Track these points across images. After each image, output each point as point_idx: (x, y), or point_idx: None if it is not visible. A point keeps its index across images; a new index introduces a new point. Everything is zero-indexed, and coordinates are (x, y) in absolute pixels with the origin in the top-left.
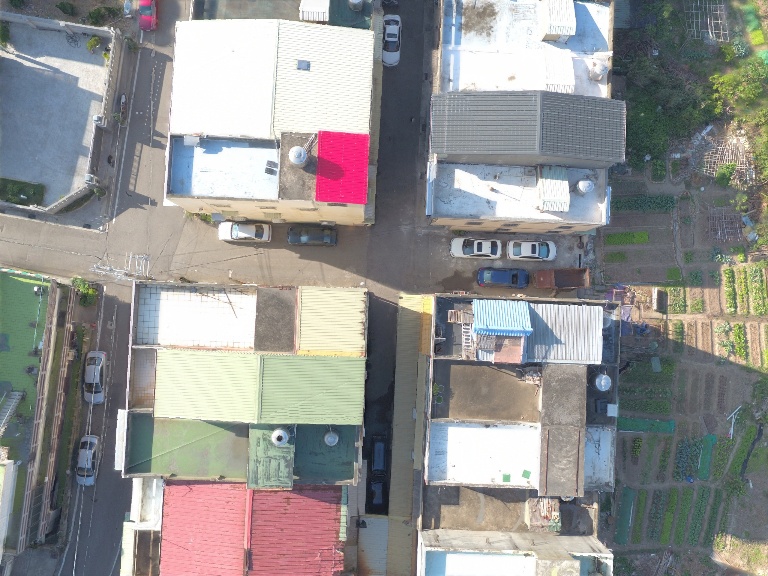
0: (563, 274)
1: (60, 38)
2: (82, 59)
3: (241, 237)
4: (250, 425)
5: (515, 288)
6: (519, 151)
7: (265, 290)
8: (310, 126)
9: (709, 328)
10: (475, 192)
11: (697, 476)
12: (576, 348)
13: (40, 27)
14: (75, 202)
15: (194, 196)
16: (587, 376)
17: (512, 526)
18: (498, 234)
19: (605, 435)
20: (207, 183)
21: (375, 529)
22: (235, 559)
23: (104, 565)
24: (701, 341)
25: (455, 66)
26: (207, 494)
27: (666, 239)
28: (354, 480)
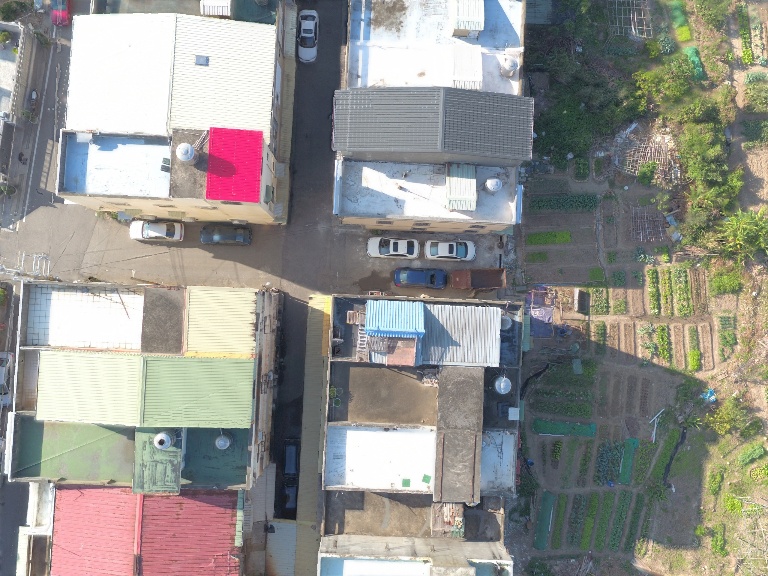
0: (481, 274)
1: None
2: None
3: (152, 236)
4: (136, 428)
5: (433, 288)
6: (421, 149)
7: (152, 290)
8: (208, 123)
9: (632, 330)
10: (383, 190)
11: (618, 480)
12: (473, 350)
13: None
14: None
15: (86, 194)
16: (489, 379)
17: (418, 531)
18: (416, 233)
19: (508, 439)
20: (101, 181)
21: (283, 534)
22: (125, 565)
23: (11, 570)
24: (624, 343)
25: (364, 62)
26: (98, 498)
27: (589, 239)
28: (246, 485)
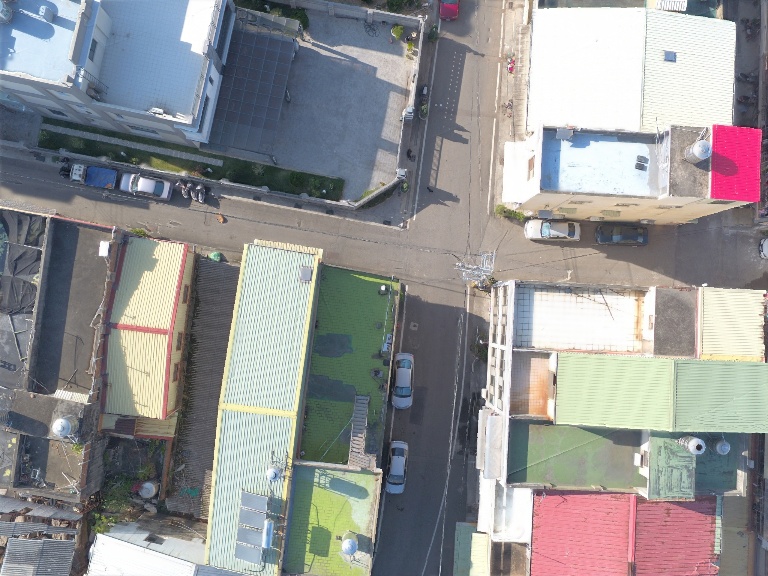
0: None
1: (357, 26)
2: (380, 49)
3: (554, 235)
4: (650, 433)
5: None
6: None
7: (664, 291)
8: (676, 120)
9: None
10: None
11: None
12: None
13: (337, 15)
14: (379, 197)
15: (569, 192)
16: None
17: None
18: None
19: None
20: (575, 178)
21: None
22: (618, 573)
23: None
24: None
25: None
26: (584, 505)
27: None
28: (743, 491)
